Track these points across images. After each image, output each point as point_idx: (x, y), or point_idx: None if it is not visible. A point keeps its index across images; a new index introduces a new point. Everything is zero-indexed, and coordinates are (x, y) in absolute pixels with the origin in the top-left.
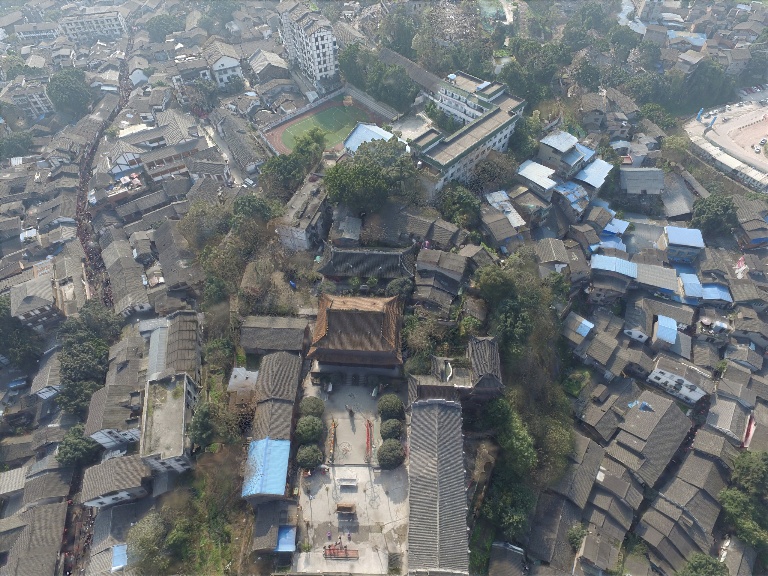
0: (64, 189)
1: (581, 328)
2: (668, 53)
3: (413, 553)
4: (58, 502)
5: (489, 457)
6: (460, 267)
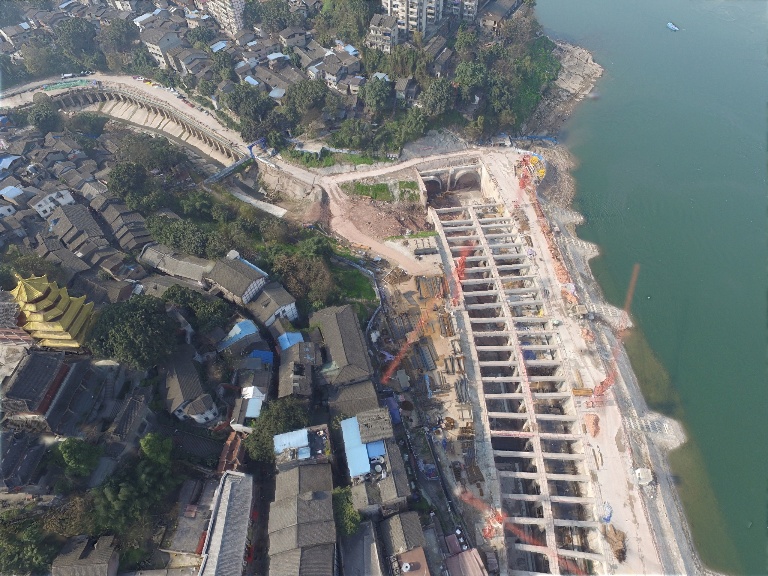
0: None
1: None
2: None
3: (5, 322)
4: None
5: None
6: None
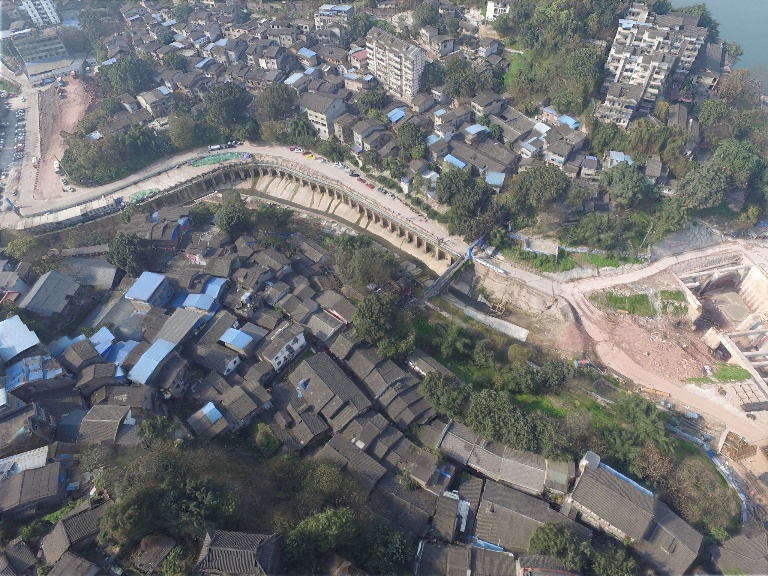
0: None
1: (211, 417)
2: None
3: None
4: None
5: (343, 567)
6: (79, 566)
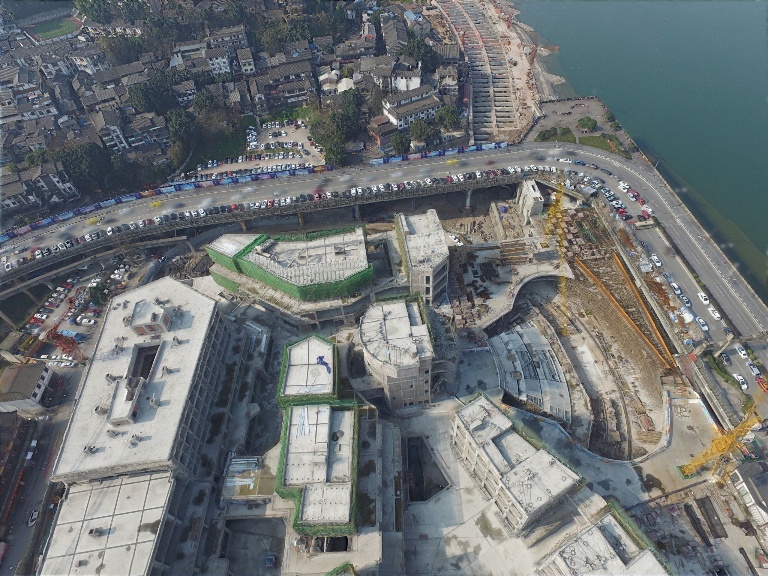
0: (17, 123)
1: None
2: None
3: None
4: (248, 81)
5: None
6: None
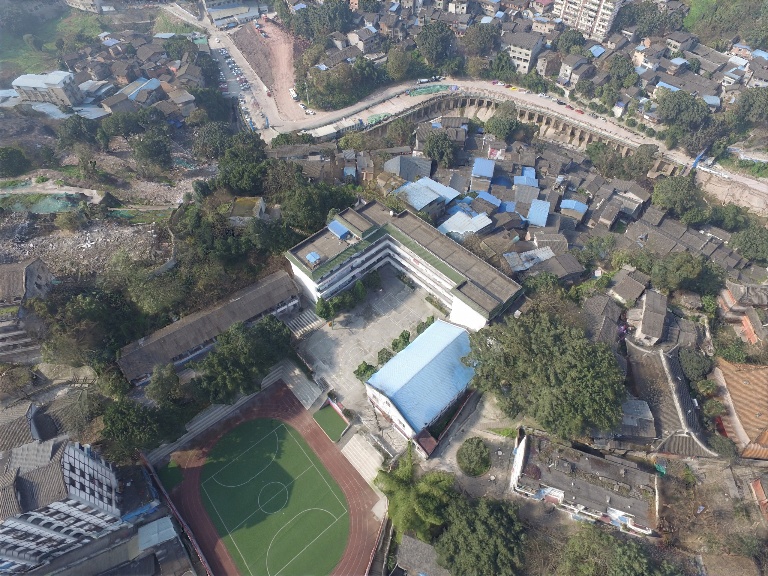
0: None
1: None
2: (162, 108)
3: None
4: None
5: None
6: (662, 297)
